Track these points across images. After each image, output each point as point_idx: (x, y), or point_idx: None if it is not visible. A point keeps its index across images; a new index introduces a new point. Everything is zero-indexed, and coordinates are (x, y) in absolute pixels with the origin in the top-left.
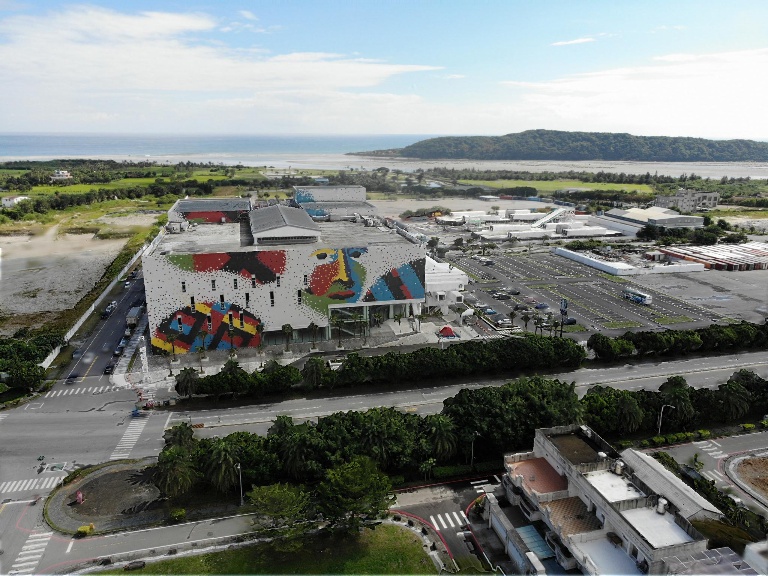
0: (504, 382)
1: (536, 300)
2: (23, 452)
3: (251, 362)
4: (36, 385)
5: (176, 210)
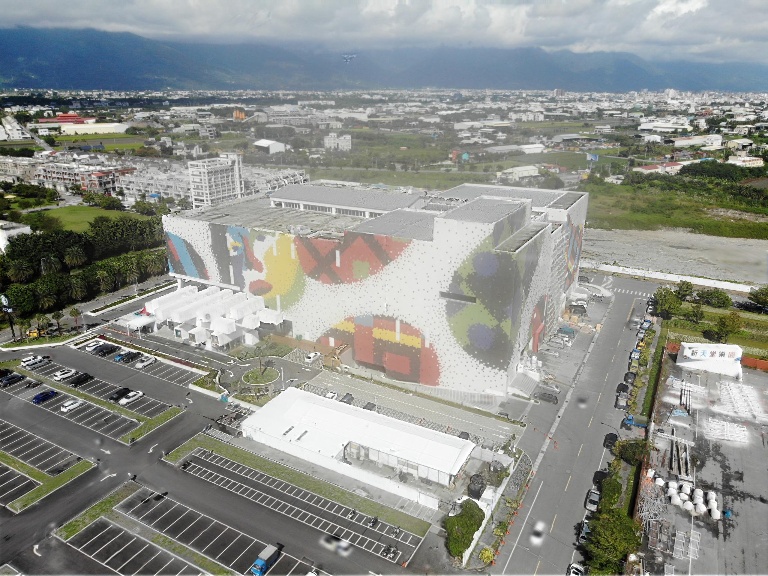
0: None
1: (61, 416)
2: None
3: None
4: None
5: (490, 187)
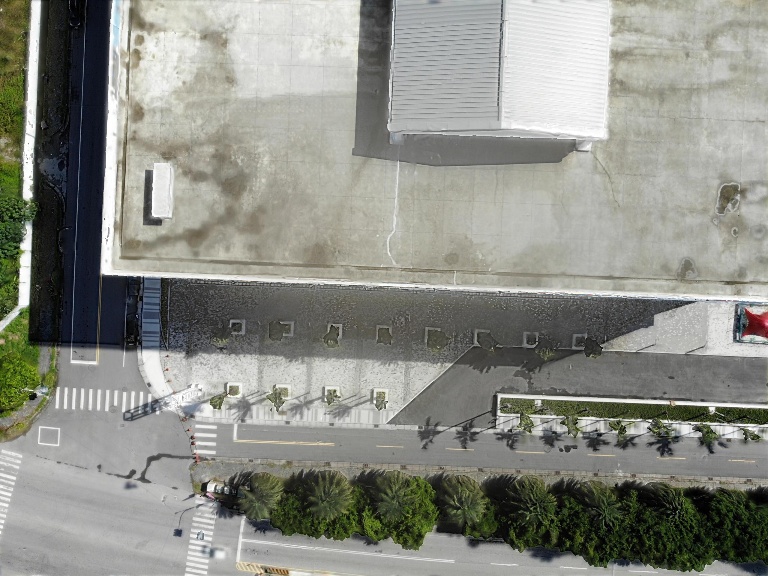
0: (759, 563)
1: None
2: (71, 574)
3: (365, 361)
4: (31, 364)
5: None
